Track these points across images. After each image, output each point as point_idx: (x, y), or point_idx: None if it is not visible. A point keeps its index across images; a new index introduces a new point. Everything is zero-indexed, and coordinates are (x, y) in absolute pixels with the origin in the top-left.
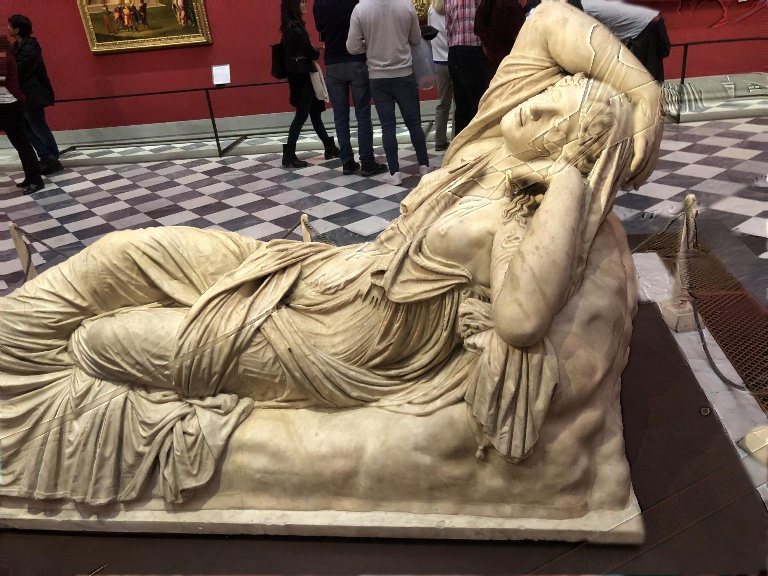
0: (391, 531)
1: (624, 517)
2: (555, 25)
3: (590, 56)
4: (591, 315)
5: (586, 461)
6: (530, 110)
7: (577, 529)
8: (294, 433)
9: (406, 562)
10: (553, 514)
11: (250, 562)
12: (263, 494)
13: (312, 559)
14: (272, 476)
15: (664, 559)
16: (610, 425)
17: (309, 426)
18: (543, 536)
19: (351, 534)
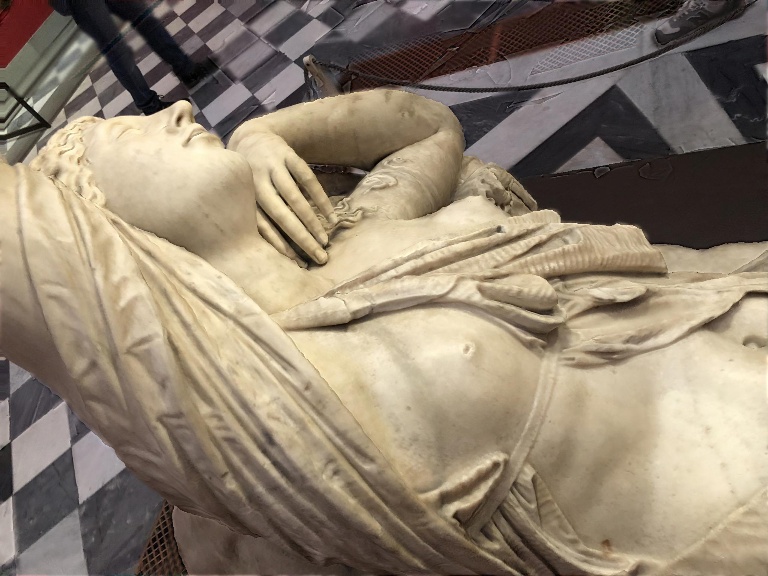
0: None
1: None
2: None
3: None
4: None
5: None
6: (190, 115)
7: None
8: None
9: None
10: None
11: None
12: None
13: None
14: None
15: None
16: None
17: None
18: None
19: None
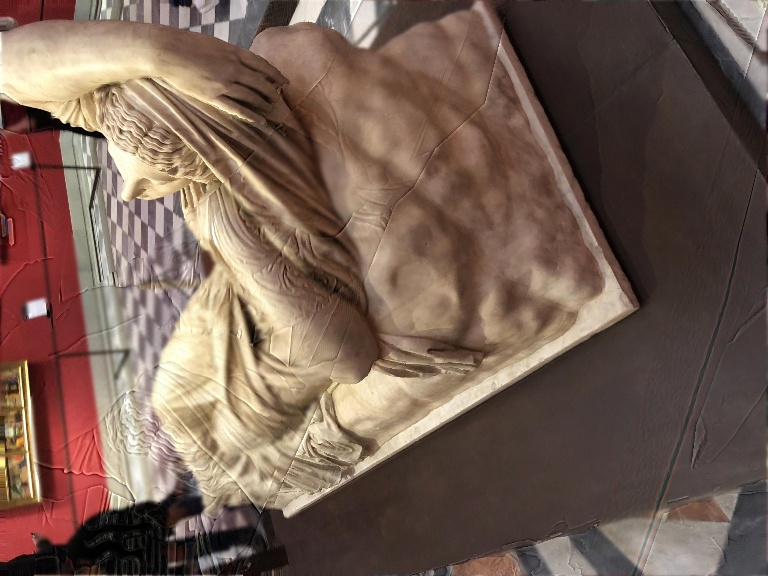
0: (473, 405)
1: (606, 301)
2: (15, 95)
3: (71, 92)
4: (388, 281)
5: (528, 313)
6: None
7: (578, 339)
8: (362, 401)
9: (501, 414)
10: (552, 338)
11: (431, 457)
12: (393, 427)
13: (455, 439)
14: (383, 424)
15: (668, 302)
16: (517, 274)
17: (364, 389)
18: (562, 352)
19: (457, 416)
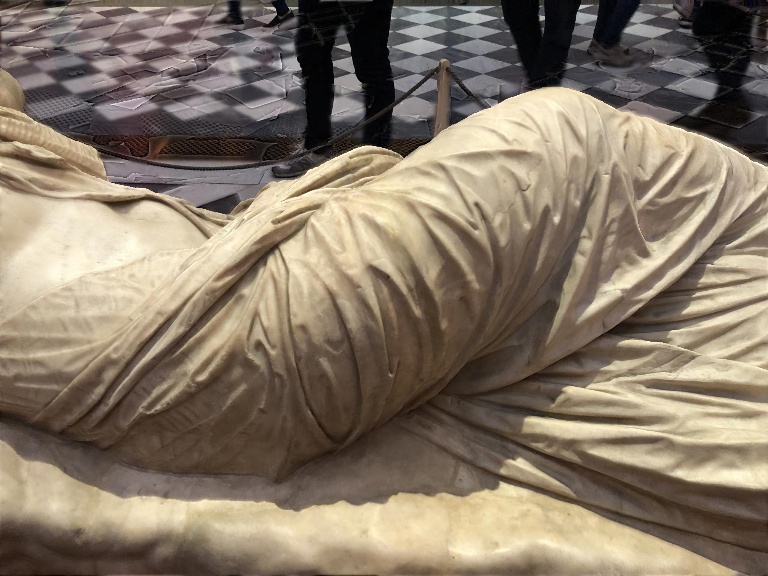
0: None
1: None
2: None
3: None
4: None
5: None
6: None
7: None
8: None
9: None
10: None
11: None
12: None
13: None
14: None
15: None
16: None
17: None
18: None
19: None
